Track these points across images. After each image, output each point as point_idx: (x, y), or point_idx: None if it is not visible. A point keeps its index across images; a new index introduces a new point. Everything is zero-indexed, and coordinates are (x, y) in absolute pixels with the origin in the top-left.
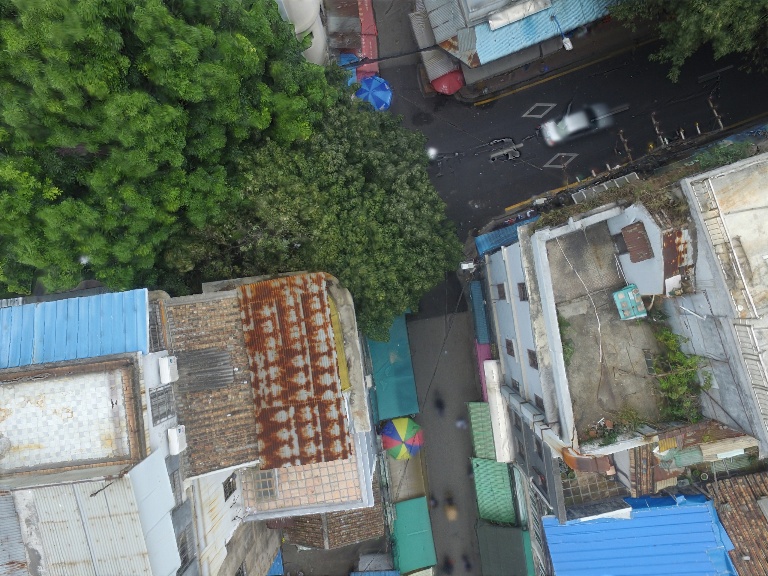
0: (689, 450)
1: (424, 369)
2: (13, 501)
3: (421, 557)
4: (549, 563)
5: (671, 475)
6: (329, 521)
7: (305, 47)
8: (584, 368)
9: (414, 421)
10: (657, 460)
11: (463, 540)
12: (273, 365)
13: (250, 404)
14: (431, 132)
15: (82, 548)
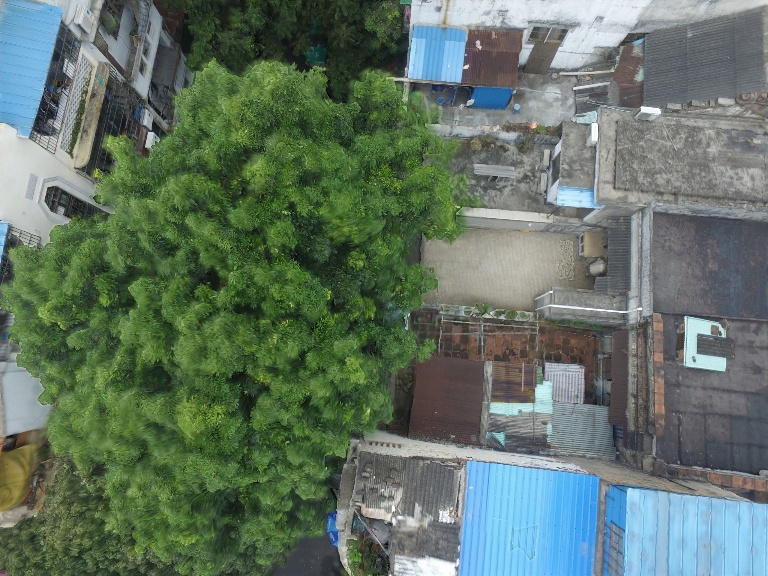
0: None
1: None
2: None
3: None
4: None
5: None
6: None
7: (256, 556)
8: None
9: None
10: None
11: None
12: None
13: None
14: (312, 573)
15: None
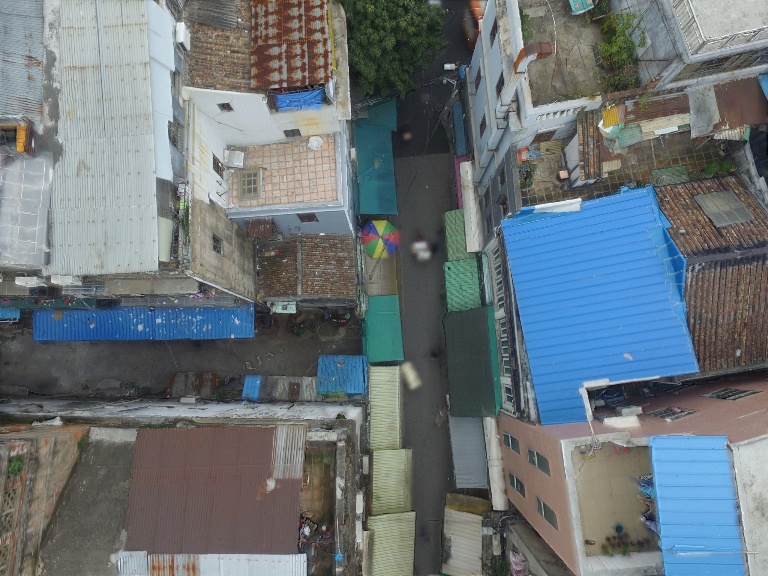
0: (630, 129)
1: (406, 200)
2: (42, 3)
3: (389, 351)
4: (508, 297)
5: (615, 157)
6: (304, 271)
7: None
8: (541, 60)
9: (392, 225)
10: (602, 137)
11: (432, 361)
12: (272, 14)
13: (248, 49)
14: None
15: (93, 53)
